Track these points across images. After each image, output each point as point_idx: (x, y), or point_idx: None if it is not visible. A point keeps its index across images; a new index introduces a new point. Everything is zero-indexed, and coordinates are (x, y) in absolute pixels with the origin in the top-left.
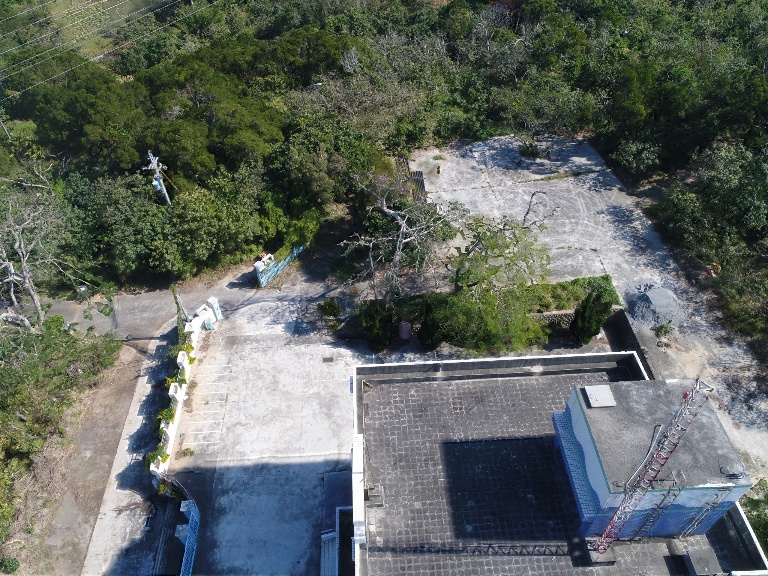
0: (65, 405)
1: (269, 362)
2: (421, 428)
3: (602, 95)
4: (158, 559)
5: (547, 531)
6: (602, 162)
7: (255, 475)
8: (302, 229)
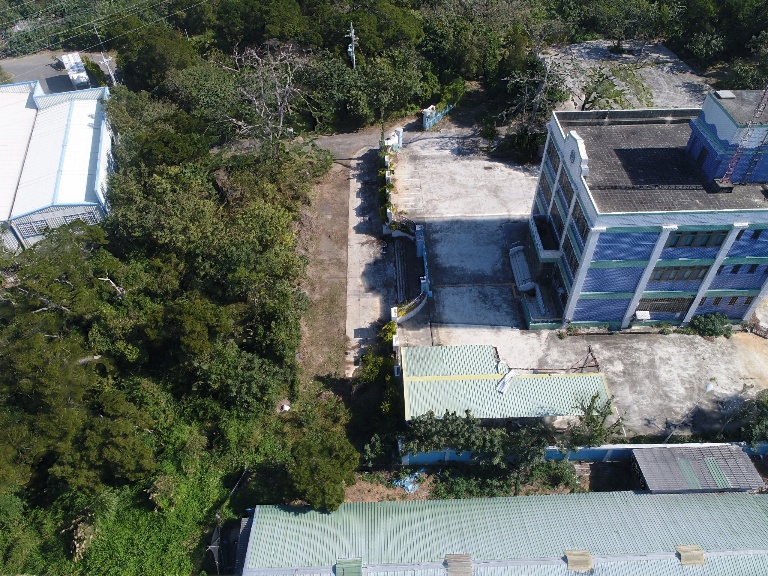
0: (306, 189)
1: (445, 169)
2: (600, 143)
3: (675, 7)
4: (398, 265)
5: (689, 181)
6: (675, 56)
7: (453, 224)
8: (455, 89)
